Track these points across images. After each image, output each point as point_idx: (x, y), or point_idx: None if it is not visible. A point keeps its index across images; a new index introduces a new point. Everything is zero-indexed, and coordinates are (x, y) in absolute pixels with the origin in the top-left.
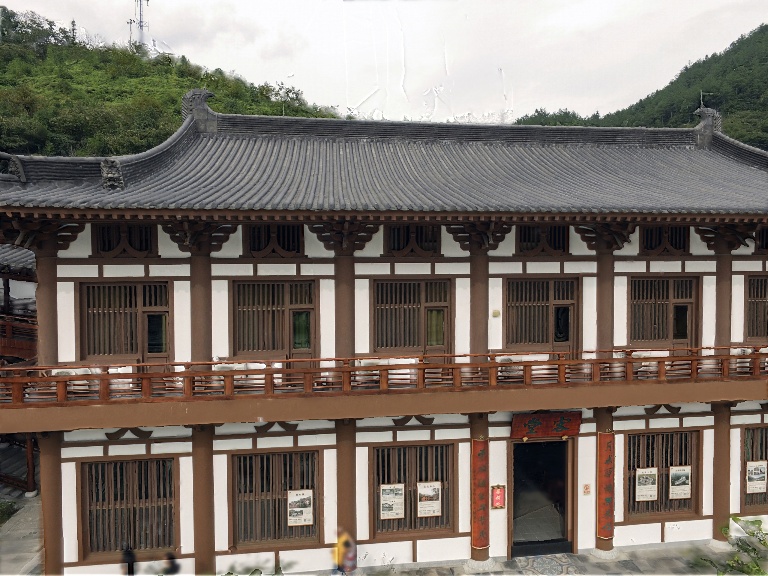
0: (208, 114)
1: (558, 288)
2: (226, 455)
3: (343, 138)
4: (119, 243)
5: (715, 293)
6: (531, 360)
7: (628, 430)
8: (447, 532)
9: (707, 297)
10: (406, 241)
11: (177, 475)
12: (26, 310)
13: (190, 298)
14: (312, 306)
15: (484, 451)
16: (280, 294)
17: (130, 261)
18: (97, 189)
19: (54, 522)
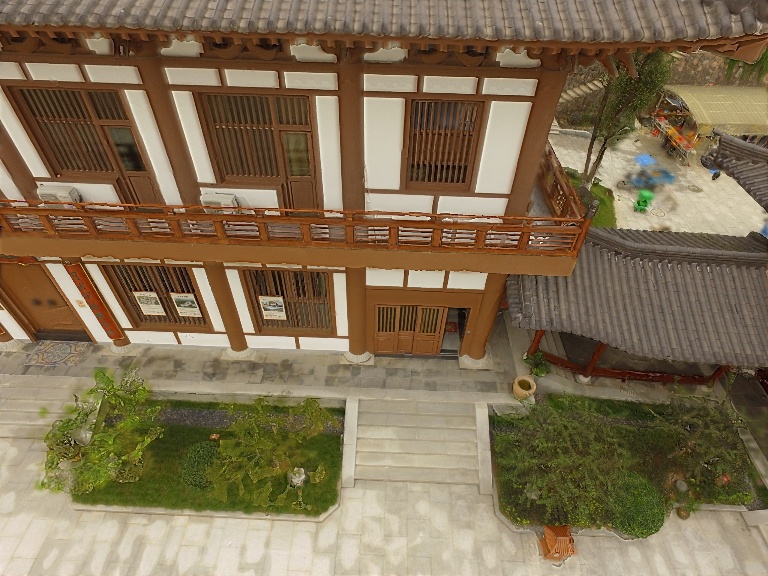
0: None
1: None
2: None
3: None
4: None
5: (153, 116)
6: None
7: (100, 261)
8: None
9: (142, 122)
10: None
11: None
12: None
13: None
14: None
15: None
16: None
17: None
18: None
19: None
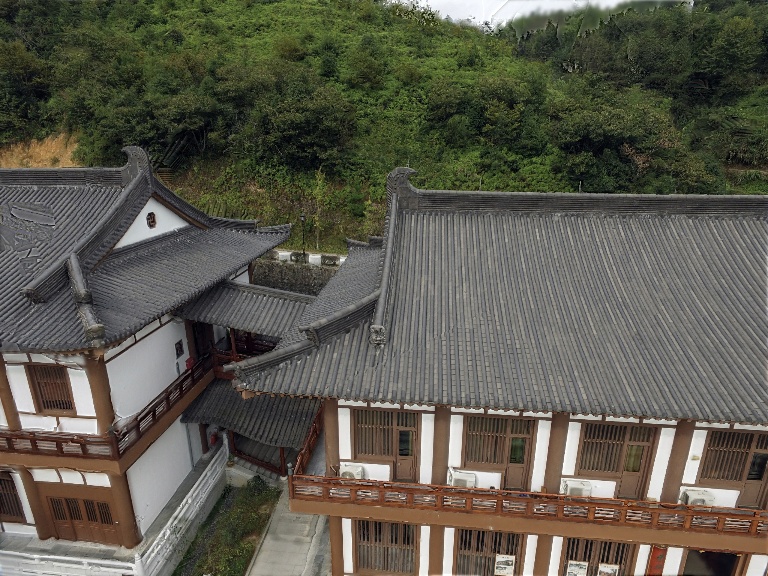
0: (410, 192)
1: (762, 439)
2: (454, 529)
3: (537, 212)
4: None
5: None
6: (721, 495)
7: None
8: None
9: None
10: None
11: (419, 536)
12: (263, 341)
13: (434, 426)
14: (529, 436)
15: (663, 556)
16: (503, 425)
17: None
18: (367, 346)
19: (338, 551)
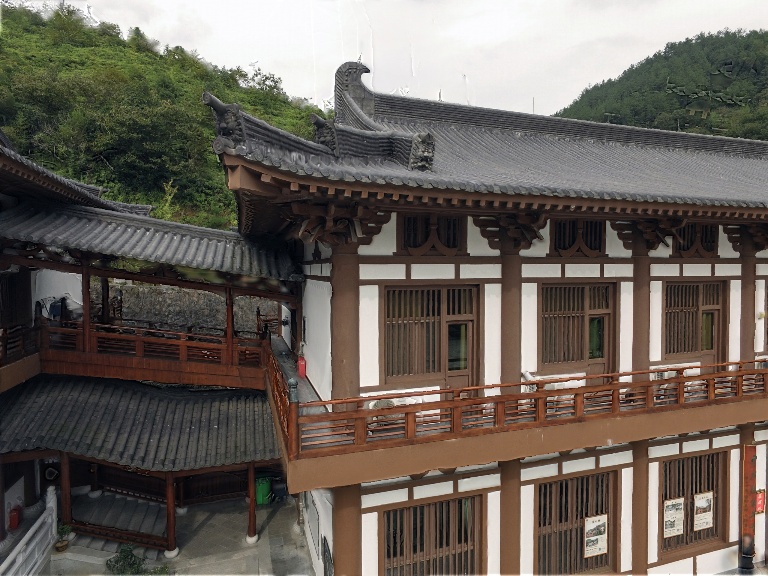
0: (365, 92)
1: None
2: (533, 485)
3: (499, 130)
4: (428, 238)
5: None
6: None
7: None
8: (718, 543)
9: None
10: (690, 241)
11: (485, 514)
12: (131, 320)
13: (501, 304)
14: (609, 311)
15: (756, 456)
16: (580, 298)
17: (440, 260)
18: None
19: None
